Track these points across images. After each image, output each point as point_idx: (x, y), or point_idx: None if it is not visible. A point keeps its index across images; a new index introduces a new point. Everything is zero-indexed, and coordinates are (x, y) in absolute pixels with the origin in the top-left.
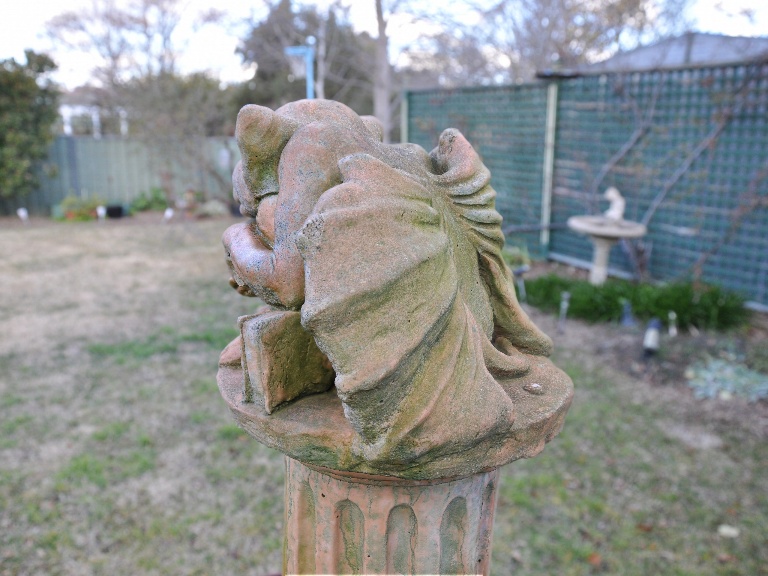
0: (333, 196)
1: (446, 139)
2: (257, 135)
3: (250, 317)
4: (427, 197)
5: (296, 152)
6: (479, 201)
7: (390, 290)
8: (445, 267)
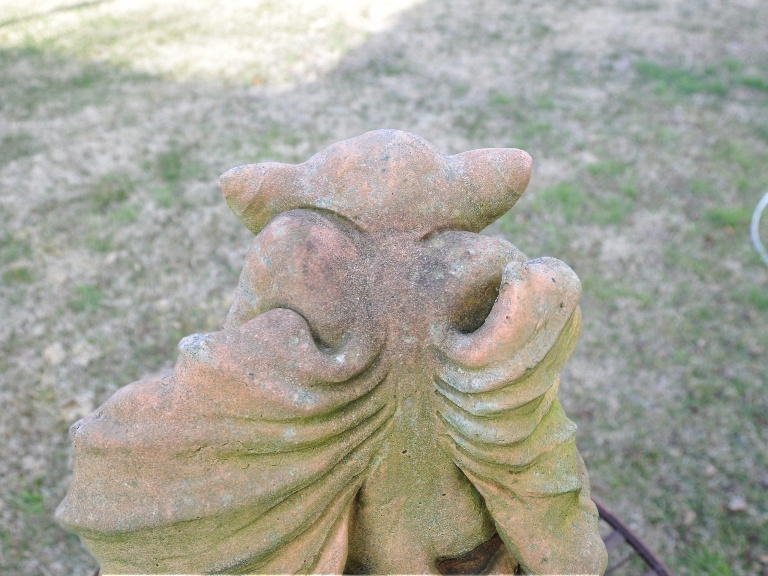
0: (115, 402)
1: (502, 278)
2: (238, 208)
3: None
4: (295, 416)
5: (247, 256)
6: (470, 408)
7: (123, 536)
8: (274, 512)
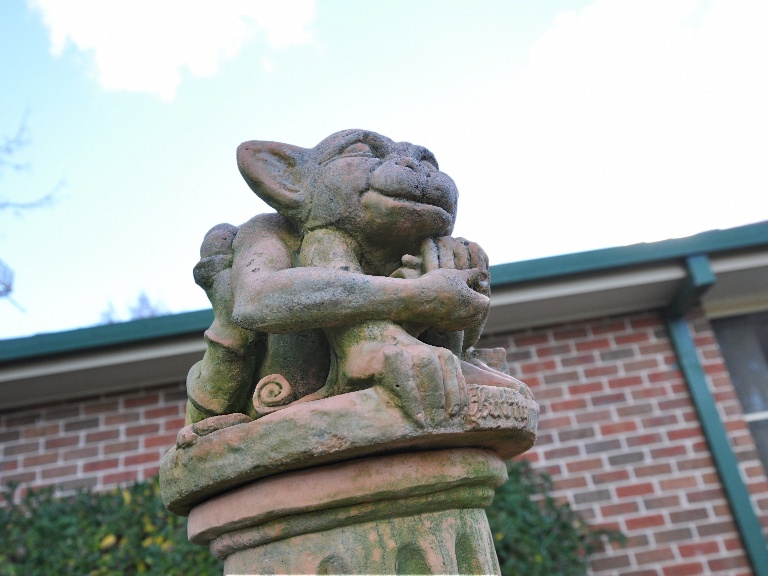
0: None
1: None
2: None
3: (493, 350)
4: None
5: None
6: None
7: None
8: None
